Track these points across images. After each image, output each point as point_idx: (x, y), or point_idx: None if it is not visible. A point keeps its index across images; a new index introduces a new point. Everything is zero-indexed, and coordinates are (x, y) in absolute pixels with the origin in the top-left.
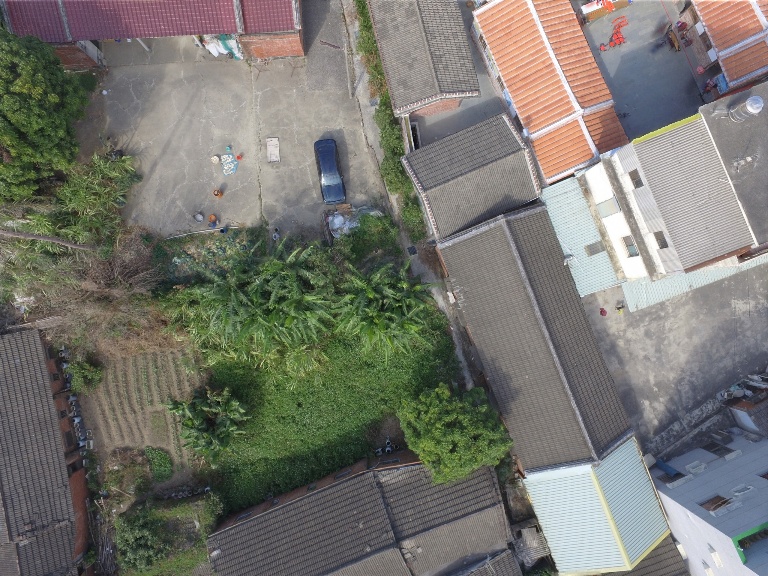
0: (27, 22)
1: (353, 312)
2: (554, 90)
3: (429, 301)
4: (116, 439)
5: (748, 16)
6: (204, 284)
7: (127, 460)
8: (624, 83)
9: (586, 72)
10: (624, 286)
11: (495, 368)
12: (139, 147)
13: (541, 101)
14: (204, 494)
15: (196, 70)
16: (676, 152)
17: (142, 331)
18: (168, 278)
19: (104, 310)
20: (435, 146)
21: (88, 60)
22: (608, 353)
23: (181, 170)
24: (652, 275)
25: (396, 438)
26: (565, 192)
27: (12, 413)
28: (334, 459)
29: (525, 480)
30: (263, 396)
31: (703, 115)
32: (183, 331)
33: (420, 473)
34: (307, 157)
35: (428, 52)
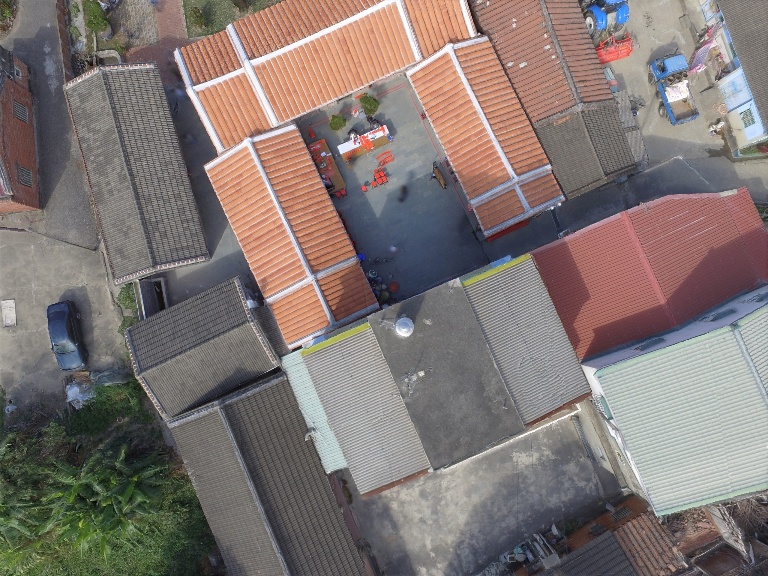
0: None
1: None
2: (286, 252)
3: (182, 470)
4: None
5: (496, 163)
6: None
7: None
8: (391, 223)
9: (324, 229)
10: None
11: (230, 559)
12: None
13: (275, 263)
14: None
15: None
16: (347, 364)
17: None
18: None
19: None
20: (161, 317)
21: None
22: (380, 517)
23: None
24: None
25: None
26: None
27: None
28: None
29: None
30: None
31: (370, 326)
32: None
33: None
34: (46, 319)
35: (140, 221)
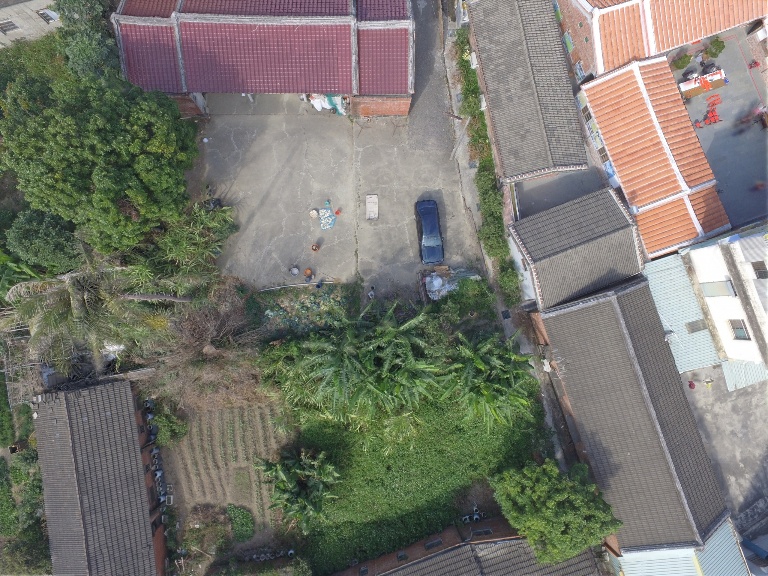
0: (143, 71)
1: (457, 380)
2: (661, 168)
3: None
4: (197, 495)
5: None
6: (300, 341)
7: (209, 518)
8: (717, 159)
9: (691, 151)
10: (724, 365)
11: (595, 442)
12: (237, 197)
13: (647, 177)
14: (292, 559)
15: (298, 123)
16: None
17: (232, 385)
18: (269, 335)
19: (214, 371)
20: (542, 216)
21: (195, 109)
22: None
23: (278, 222)
24: (767, 363)
25: (483, 505)
26: (668, 268)
27: (101, 468)
28: (421, 525)
29: (621, 558)
30: (352, 457)
31: None
32: (274, 387)
33: (519, 549)
34: (405, 216)
35: (543, 125)
